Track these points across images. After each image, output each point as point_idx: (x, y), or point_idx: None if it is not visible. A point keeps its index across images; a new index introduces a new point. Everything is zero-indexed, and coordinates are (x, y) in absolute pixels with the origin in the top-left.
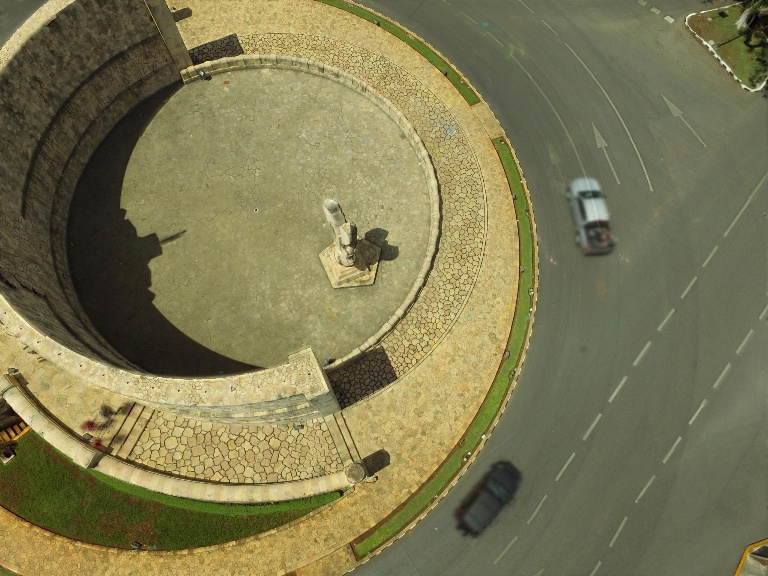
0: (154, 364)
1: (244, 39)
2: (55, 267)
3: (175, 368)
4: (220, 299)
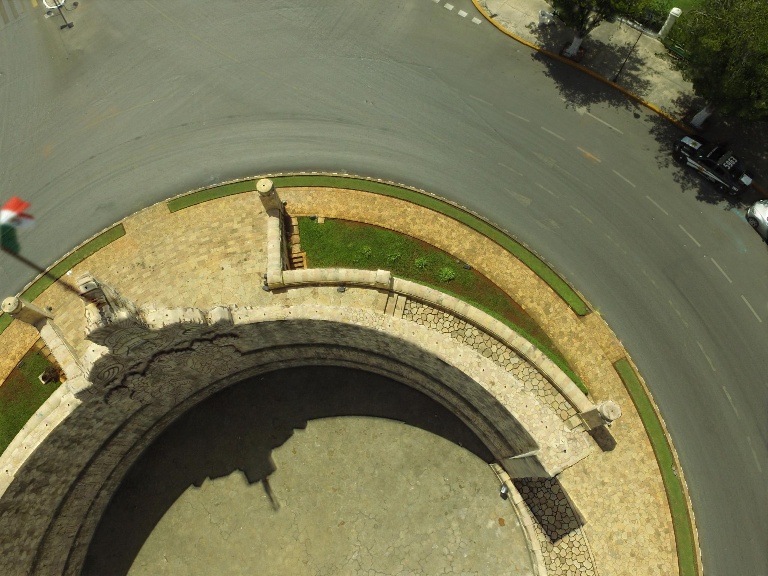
0: (120, 503)
1: (578, 539)
2: (217, 381)
3: (113, 528)
4: (191, 569)
